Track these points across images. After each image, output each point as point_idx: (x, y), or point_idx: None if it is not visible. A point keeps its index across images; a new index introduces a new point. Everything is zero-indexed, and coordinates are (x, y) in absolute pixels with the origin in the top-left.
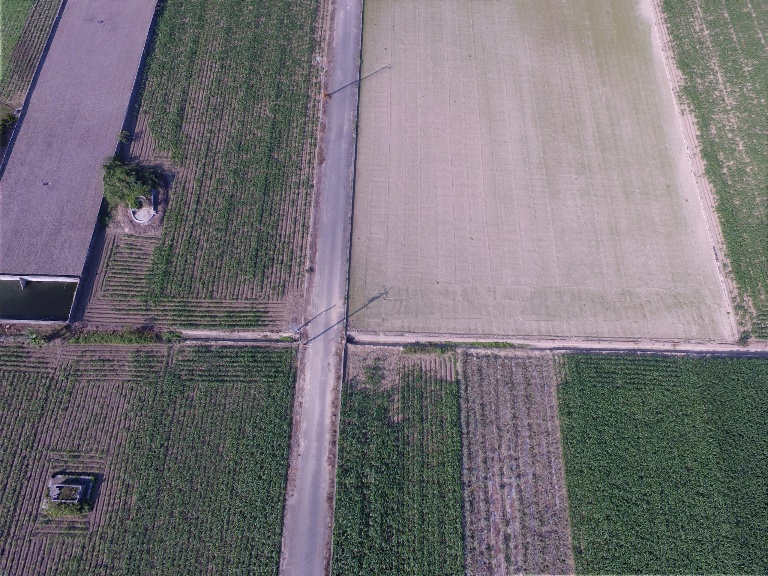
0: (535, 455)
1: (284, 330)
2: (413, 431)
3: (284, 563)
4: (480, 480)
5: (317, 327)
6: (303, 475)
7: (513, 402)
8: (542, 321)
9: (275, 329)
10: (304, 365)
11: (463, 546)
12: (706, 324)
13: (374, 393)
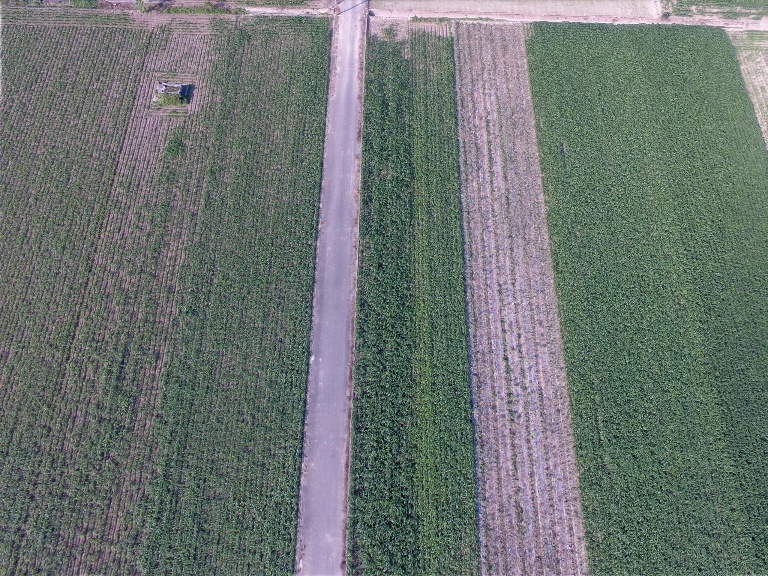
0: (508, 78)
1: (322, 8)
2: (419, 63)
3: (328, 130)
4: (468, 91)
5: (346, 5)
6: (340, 85)
7: (492, 47)
8: (515, 5)
9: (315, 7)
10: (338, 26)
11: (456, 121)
12: (638, 8)
13: (390, 43)
